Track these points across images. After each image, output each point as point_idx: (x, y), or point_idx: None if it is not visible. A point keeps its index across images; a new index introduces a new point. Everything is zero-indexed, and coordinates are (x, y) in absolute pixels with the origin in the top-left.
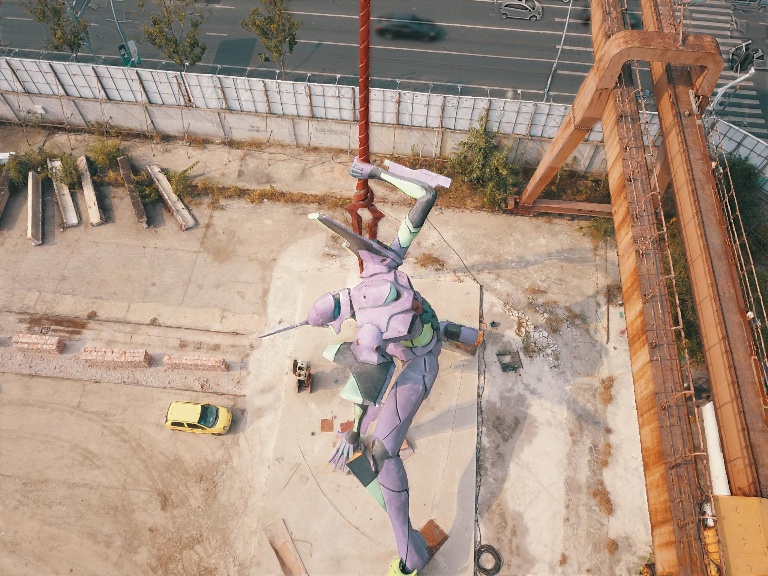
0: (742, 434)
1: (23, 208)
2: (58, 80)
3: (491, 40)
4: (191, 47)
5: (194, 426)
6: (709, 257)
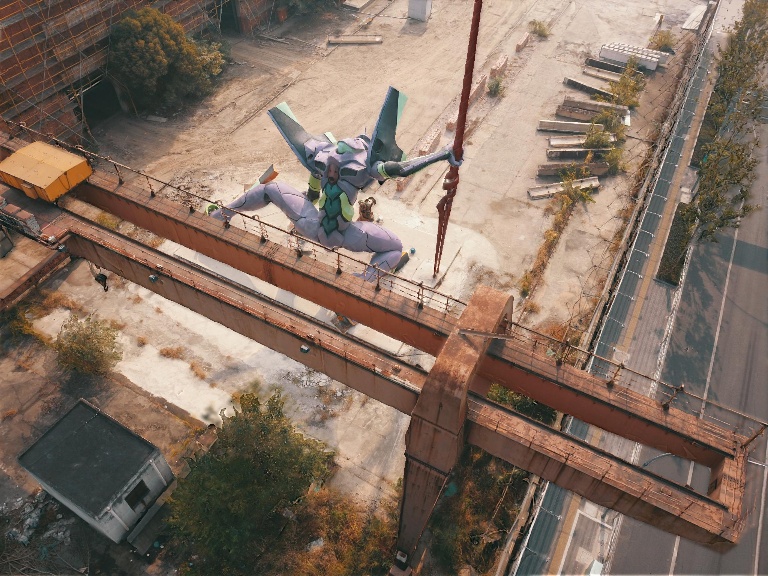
0: None
1: None
2: None
3: None
4: None
5: None
6: None
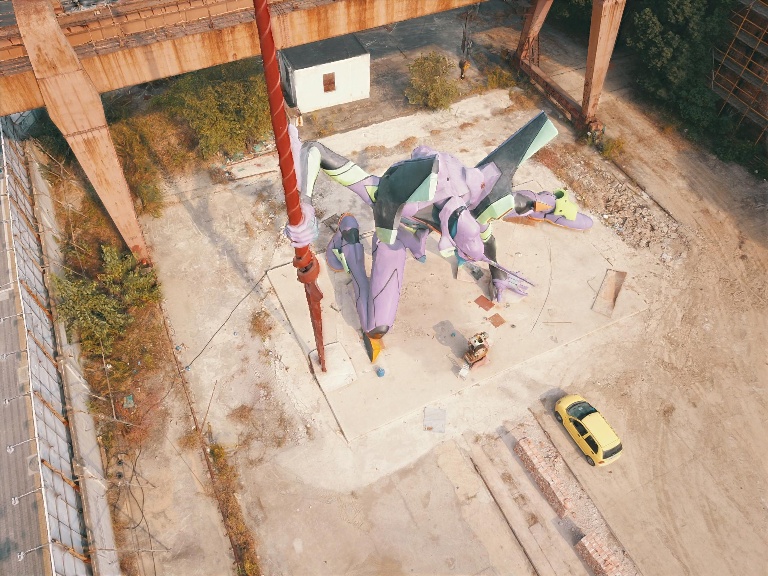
0: None
1: None
2: None
3: None
4: None
5: None
6: None
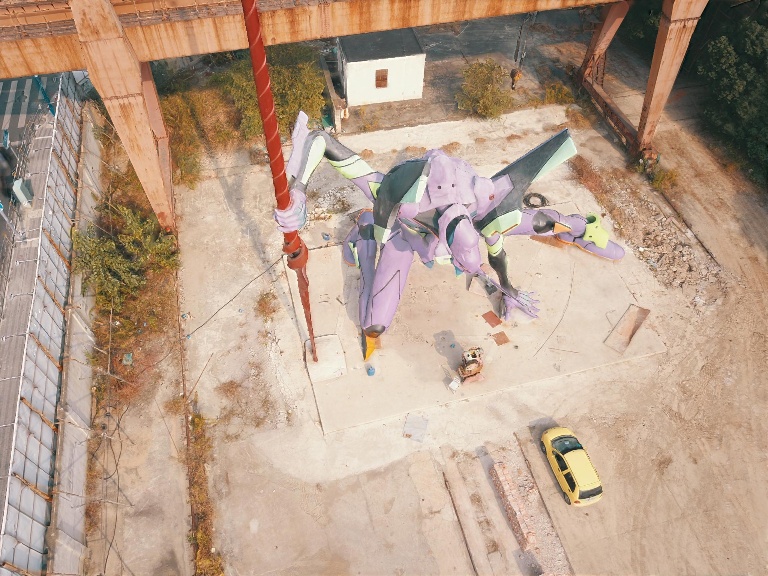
0: None
1: None
2: None
3: None
4: None
5: None
6: None
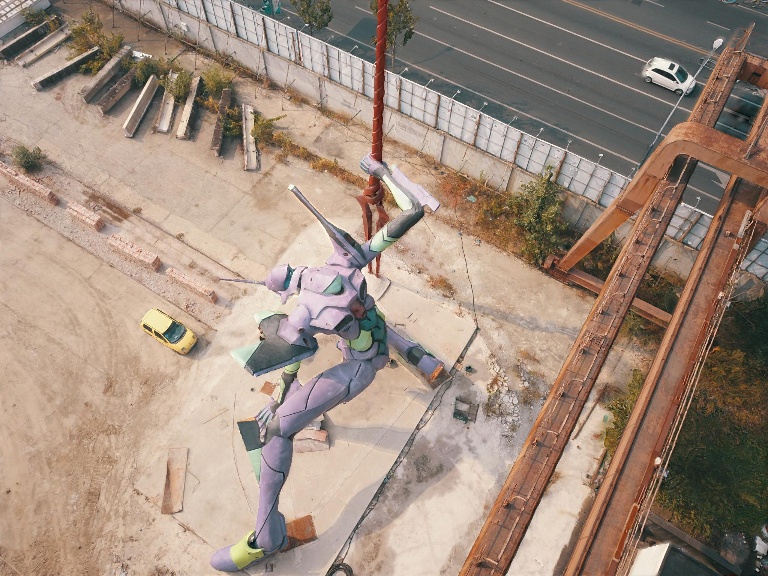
0: (573, 572)
1: (134, 103)
2: (203, 5)
3: (622, 99)
4: (323, 12)
5: (159, 336)
6: (654, 385)
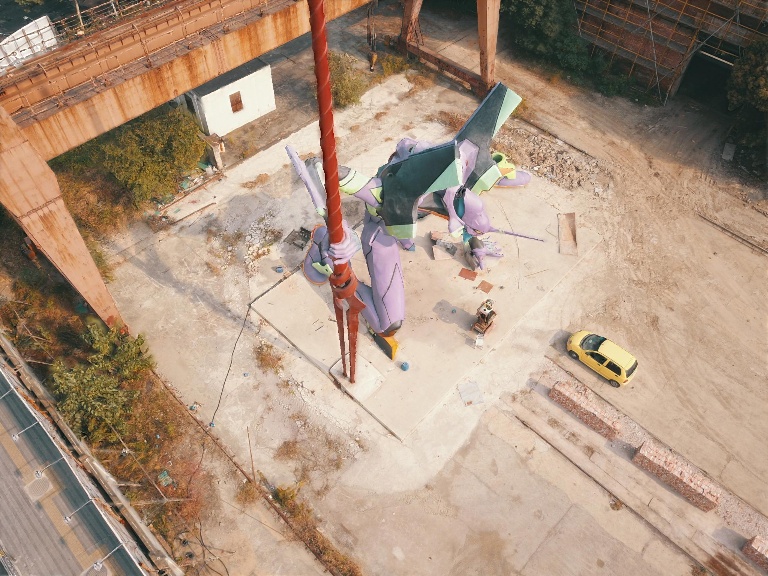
0: None
1: None
2: None
3: None
4: None
5: None
6: (188, 8)
